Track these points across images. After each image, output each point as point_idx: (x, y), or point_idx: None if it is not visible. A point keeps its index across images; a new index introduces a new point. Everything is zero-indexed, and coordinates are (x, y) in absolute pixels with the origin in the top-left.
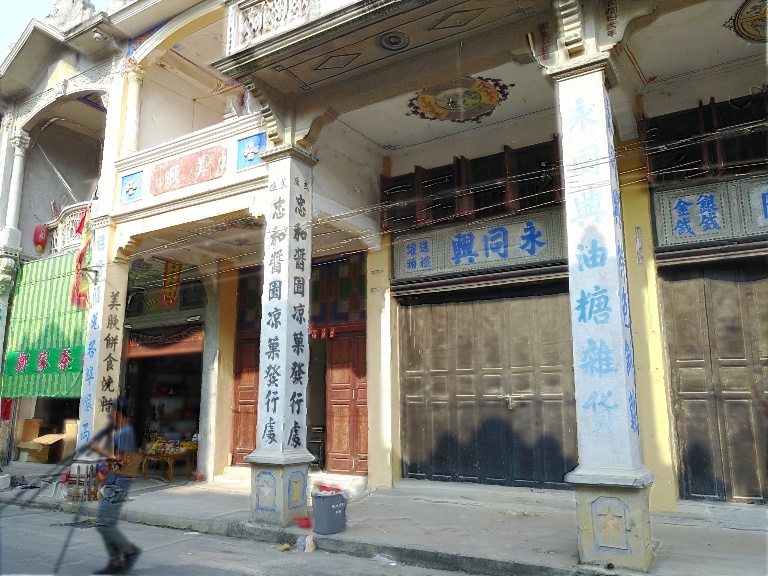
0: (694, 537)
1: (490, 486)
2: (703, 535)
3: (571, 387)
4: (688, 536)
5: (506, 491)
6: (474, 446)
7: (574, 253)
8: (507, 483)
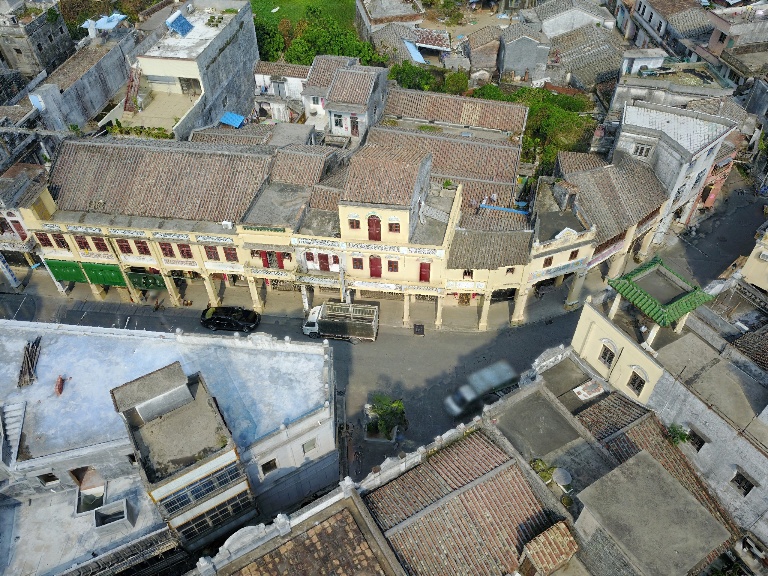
0: (35, 279)
1: (12, 266)
2: (36, 278)
3: (18, 254)
4: (34, 279)
5: (14, 268)
6: (7, 260)
7: (1, 267)
8: (14, 265)
